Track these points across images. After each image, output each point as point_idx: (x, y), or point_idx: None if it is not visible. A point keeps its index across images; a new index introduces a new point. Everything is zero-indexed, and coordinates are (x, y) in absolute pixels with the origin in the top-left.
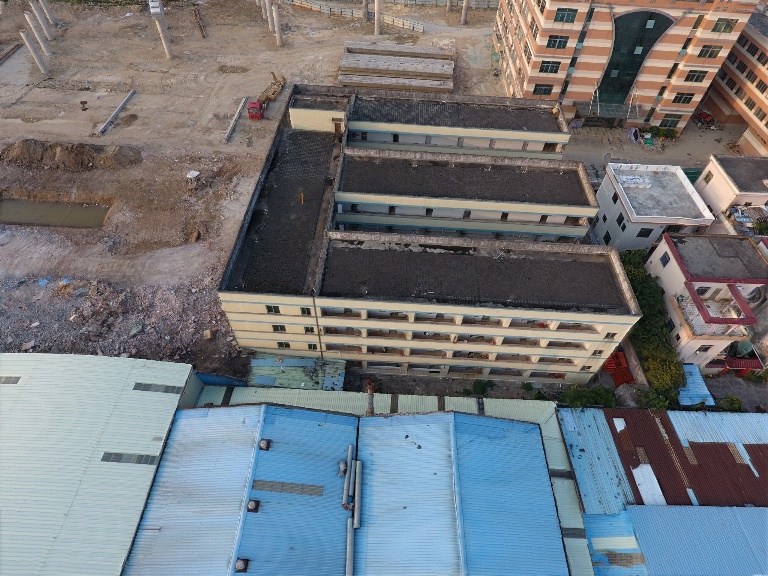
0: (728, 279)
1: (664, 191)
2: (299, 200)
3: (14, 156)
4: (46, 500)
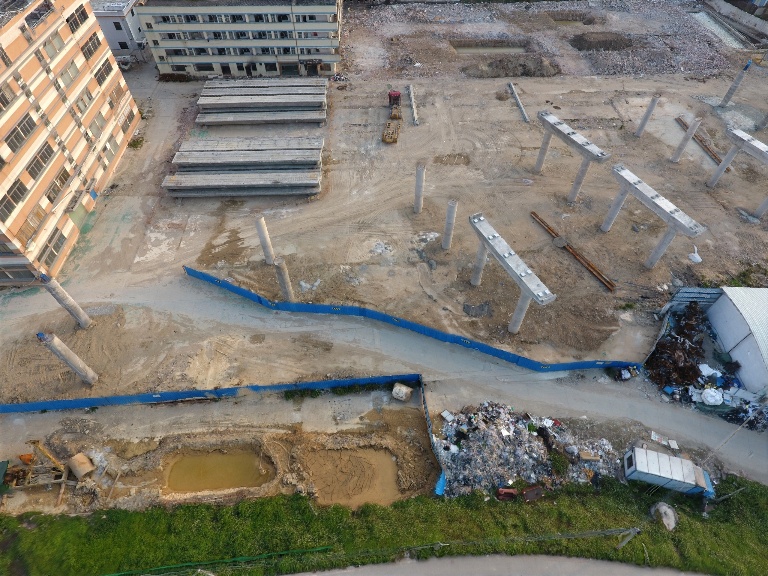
0: None
1: (99, 7)
2: None
3: None
4: None
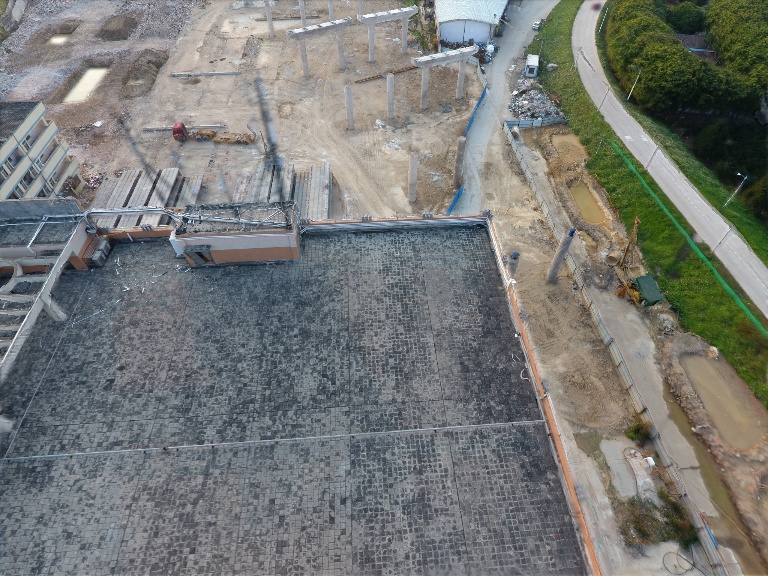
0: None
1: None
2: None
3: None
4: None
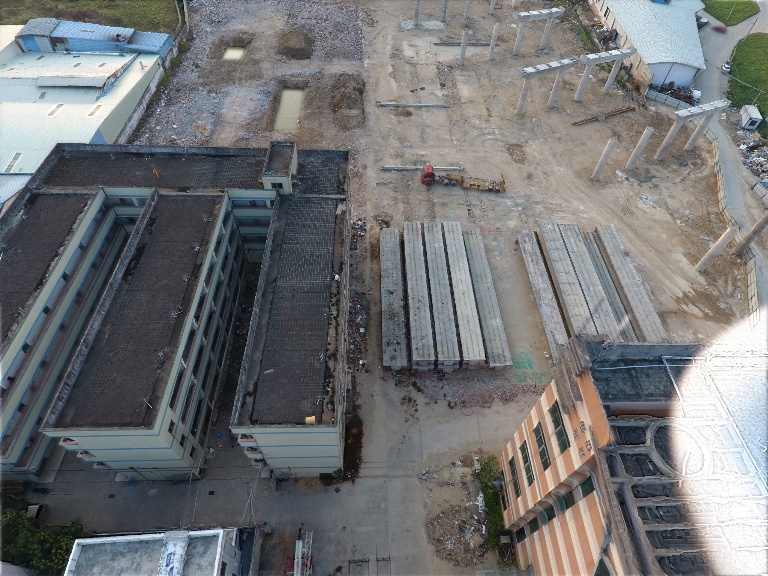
0: None
1: None
2: None
3: (341, 78)
4: (3, 141)
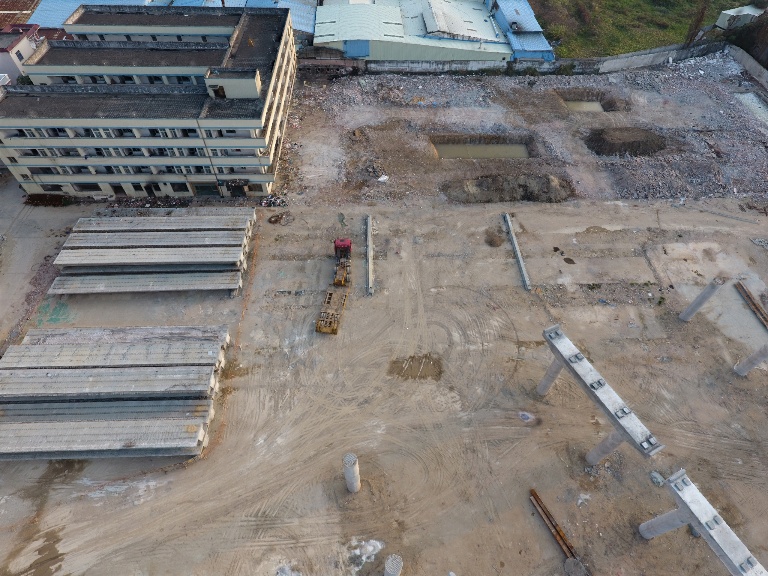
0: (1, 32)
1: None
2: (253, 45)
3: None
4: None
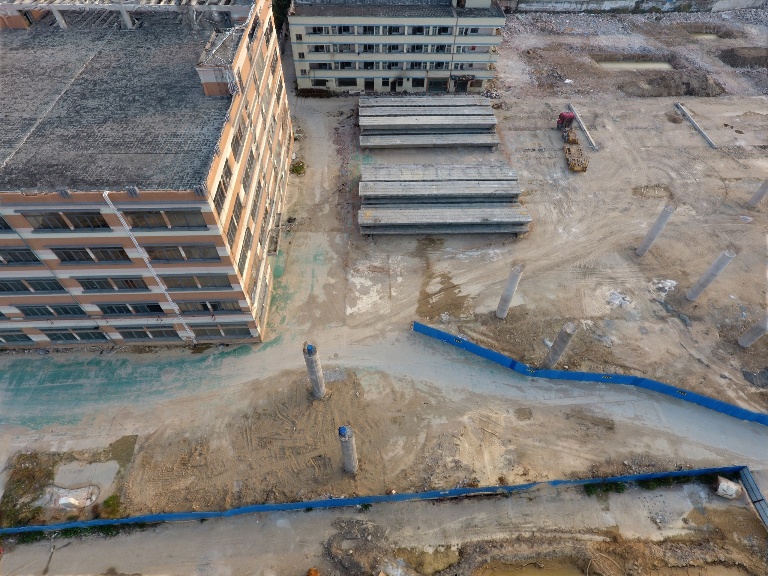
0: None
1: None
2: None
3: None
4: None
